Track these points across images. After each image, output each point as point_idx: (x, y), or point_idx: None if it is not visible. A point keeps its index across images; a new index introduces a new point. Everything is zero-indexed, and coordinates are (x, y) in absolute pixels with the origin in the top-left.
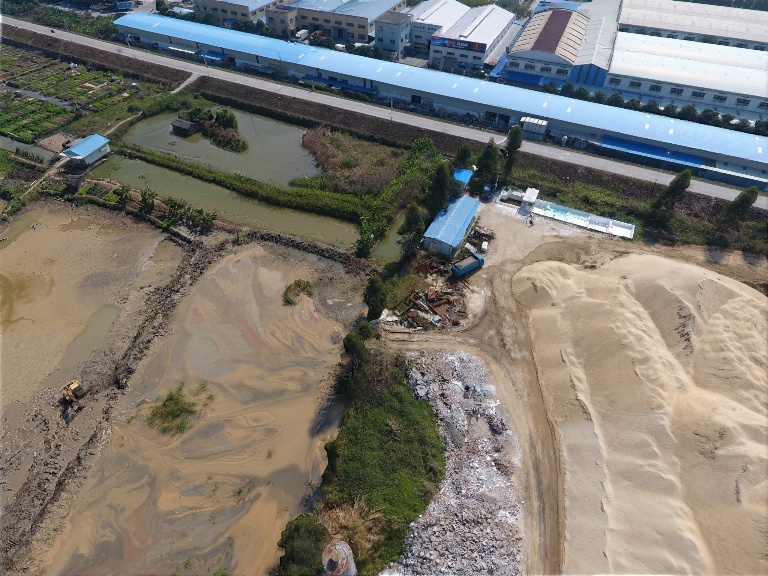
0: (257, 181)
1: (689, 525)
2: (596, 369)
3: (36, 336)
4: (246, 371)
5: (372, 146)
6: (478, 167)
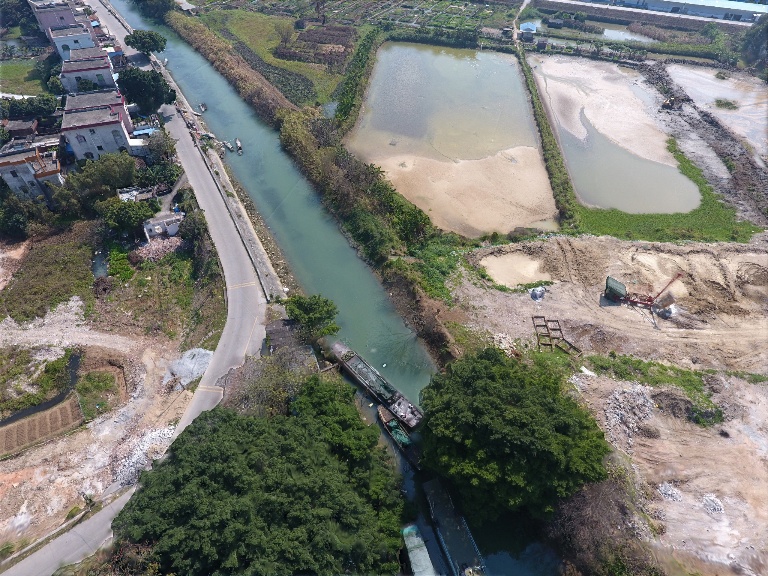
0: (641, 42)
1: None
2: None
3: (615, 93)
4: (737, 95)
5: (673, 31)
6: None
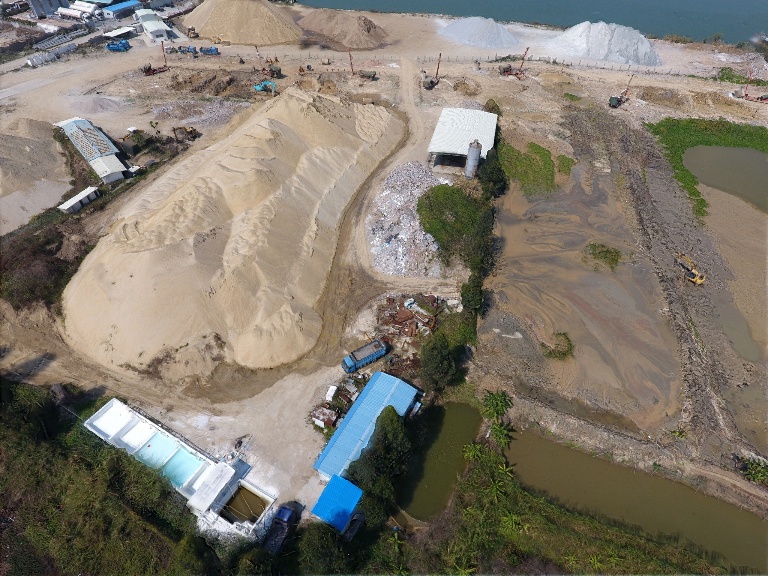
0: None
1: (302, 165)
2: (295, 235)
3: None
4: (569, 277)
5: None
6: (283, 574)
